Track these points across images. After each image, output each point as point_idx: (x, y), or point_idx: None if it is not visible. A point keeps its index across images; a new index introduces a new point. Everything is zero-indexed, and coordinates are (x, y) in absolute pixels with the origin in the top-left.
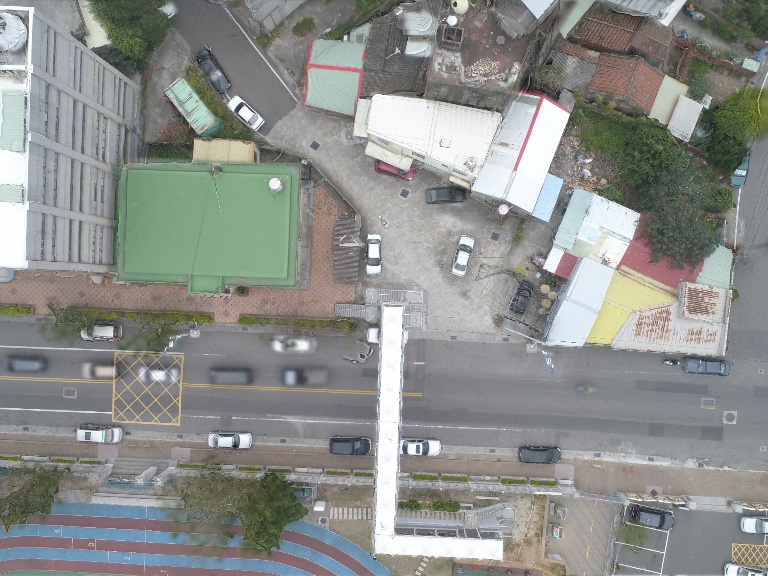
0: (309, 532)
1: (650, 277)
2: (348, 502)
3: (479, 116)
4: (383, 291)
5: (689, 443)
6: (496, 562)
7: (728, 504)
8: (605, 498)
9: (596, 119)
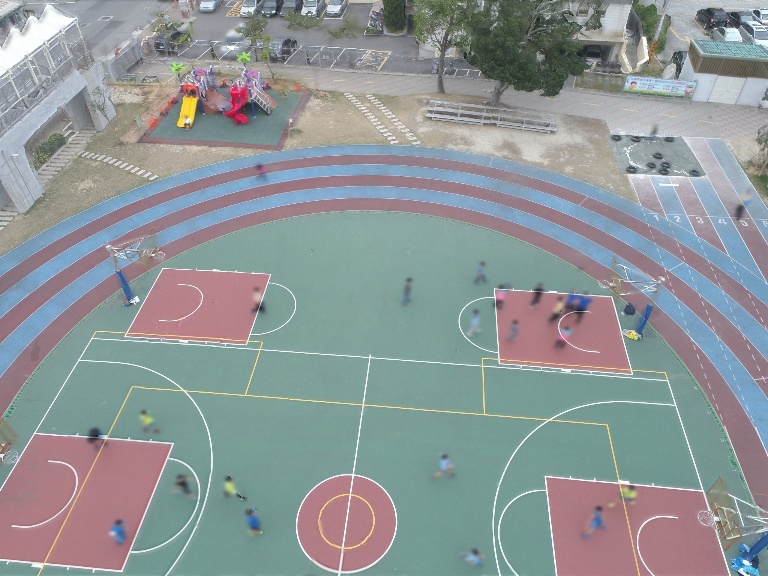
0: None
1: None
2: None
3: None
4: None
5: (115, 33)
6: (158, 112)
7: (185, 16)
8: (140, 68)
9: None
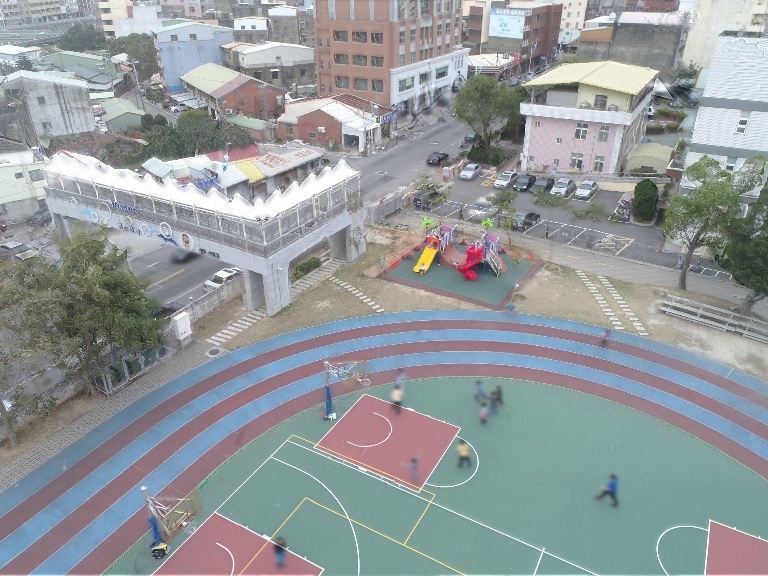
0: (212, 371)
1: (241, 160)
2: (219, 329)
3: (16, 148)
4: (47, 231)
5: (385, 186)
6: (400, 255)
7: (445, 180)
8: (396, 217)
9: (117, 164)
